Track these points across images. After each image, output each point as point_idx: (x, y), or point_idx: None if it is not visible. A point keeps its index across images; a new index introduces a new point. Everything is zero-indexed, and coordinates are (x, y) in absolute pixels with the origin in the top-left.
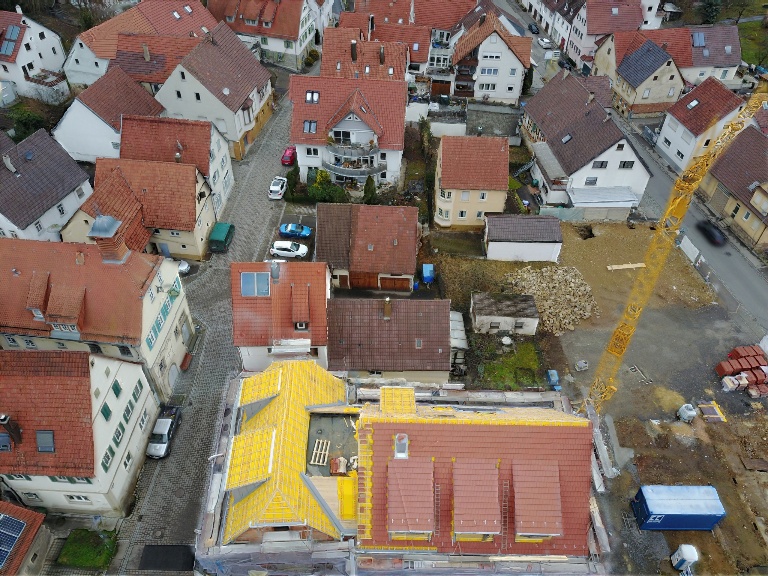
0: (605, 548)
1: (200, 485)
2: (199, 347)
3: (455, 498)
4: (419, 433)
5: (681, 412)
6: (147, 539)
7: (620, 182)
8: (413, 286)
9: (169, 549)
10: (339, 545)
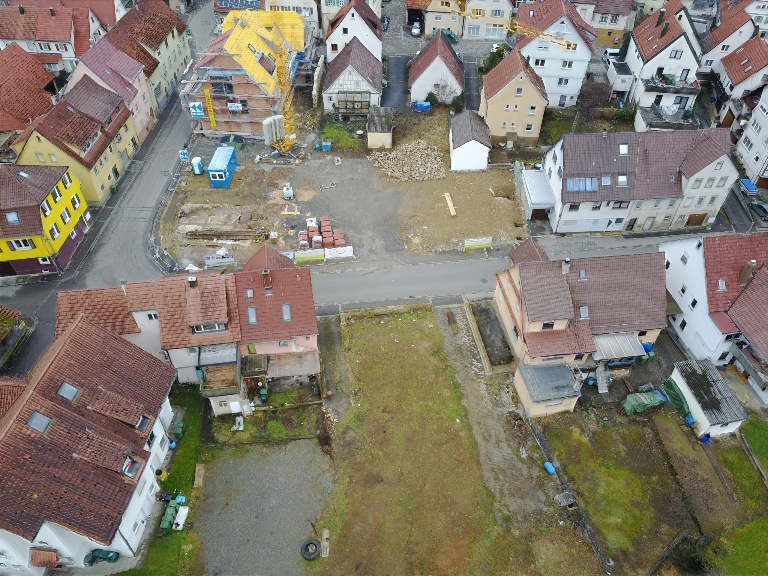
0: None
1: None
2: None
3: None
4: None
5: None
6: None
7: None
8: None
9: None
10: None
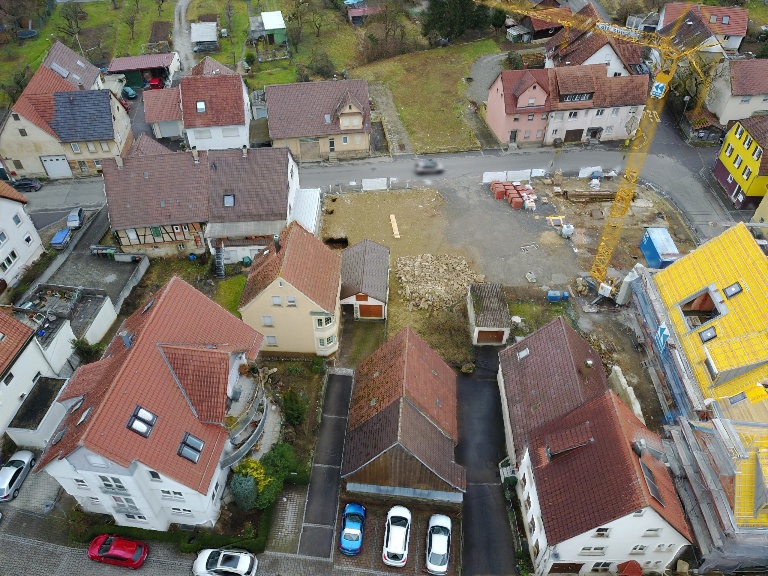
0: None
1: None
2: None
3: None
4: None
5: (568, 233)
6: None
7: None
8: None
9: None
10: None
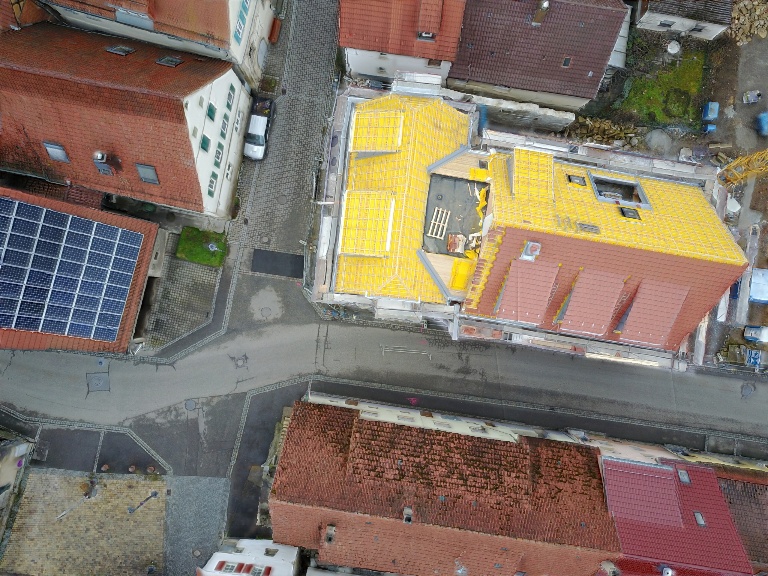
0: (698, 362)
1: (302, 193)
2: (288, 7)
3: (571, 302)
4: (554, 243)
5: None
6: (255, 243)
7: None
8: None
9: (277, 256)
10: (445, 308)
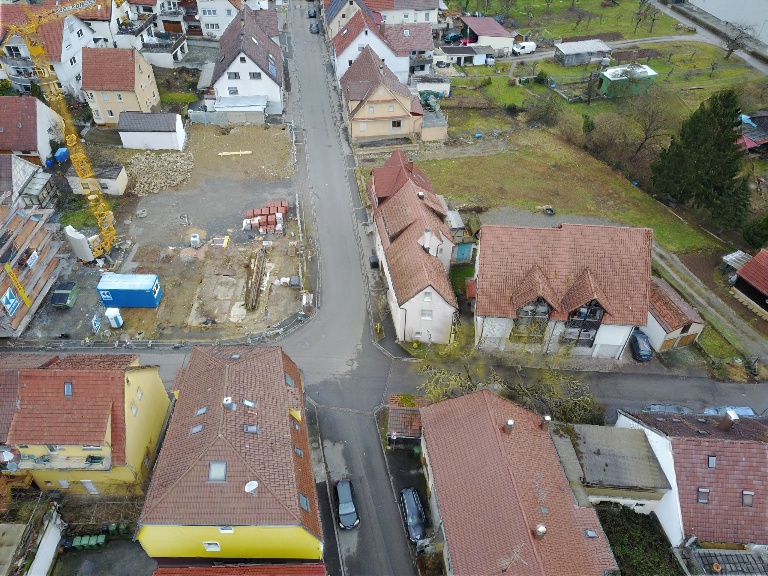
0: None
1: None
2: None
3: None
4: None
5: None
6: None
7: (257, 92)
8: (46, 163)
9: None
10: None
